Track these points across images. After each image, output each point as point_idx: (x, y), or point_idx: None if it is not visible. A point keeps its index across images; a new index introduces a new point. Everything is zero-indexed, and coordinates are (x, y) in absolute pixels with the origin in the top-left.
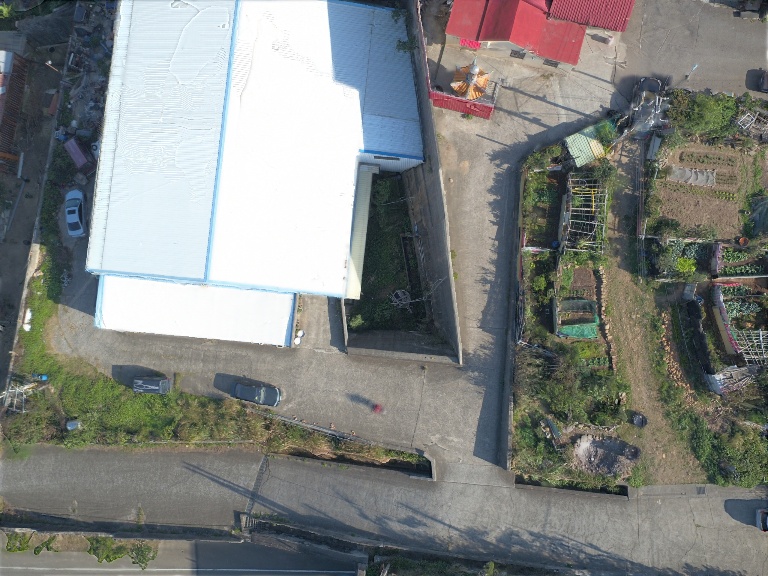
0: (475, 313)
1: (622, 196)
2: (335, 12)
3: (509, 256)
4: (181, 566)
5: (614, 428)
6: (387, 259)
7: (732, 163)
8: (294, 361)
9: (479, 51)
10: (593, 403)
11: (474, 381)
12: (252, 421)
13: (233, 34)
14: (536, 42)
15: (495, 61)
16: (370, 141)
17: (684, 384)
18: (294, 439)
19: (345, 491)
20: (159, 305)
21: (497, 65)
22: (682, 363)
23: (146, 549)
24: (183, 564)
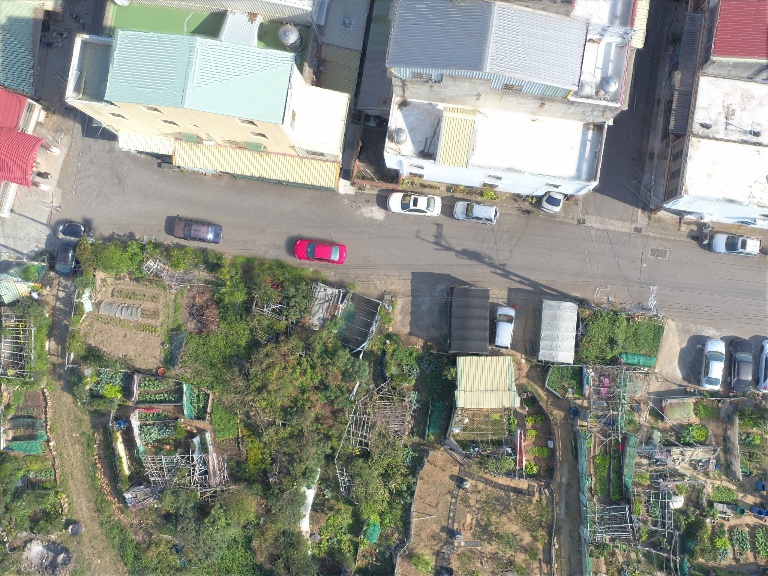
0: None
1: (62, 326)
2: None
3: None
4: None
5: (57, 535)
6: None
7: (155, 300)
8: None
9: None
10: (41, 511)
11: None
12: None
13: None
14: None
15: None
16: None
17: (113, 498)
18: None
19: None
20: None
21: None
22: (111, 479)
23: None
24: None
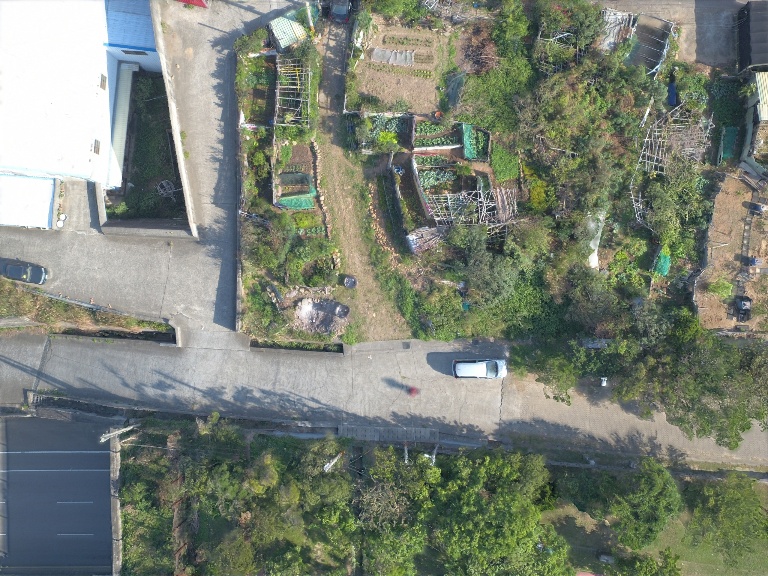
0: (208, 190)
1: (332, 77)
2: None
3: (234, 136)
4: None
5: (330, 291)
6: (154, 153)
7: (429, 44)
8: (59, 243)
9: None
10: (312, 269)
11: (212, 254)
12: (21, 298)
13: None
14: None
15: None
16: (115, 36)
17: (389, 248)
18: (57, 313)
19: (111, 363)
20: None
21: None
22: (387, 229)
23: None
24: None
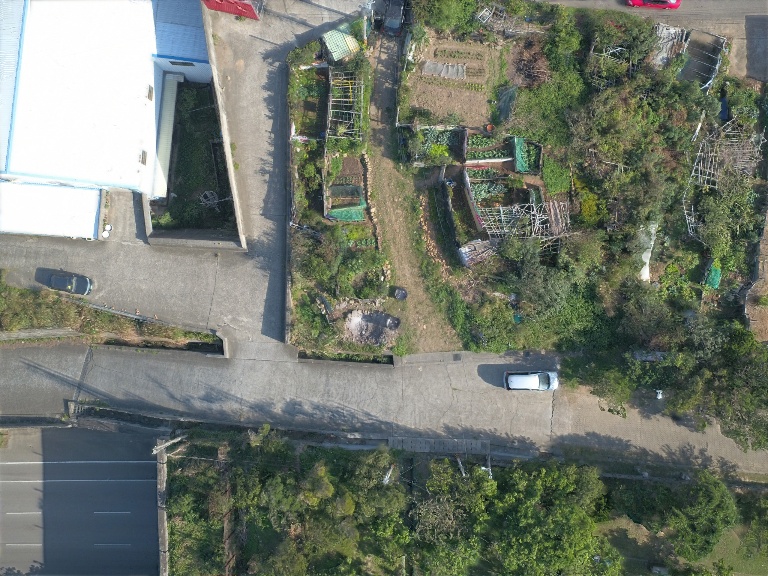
0: (257, 201)
1: (383, 90)
2: None
3: (284, 147)
4: (29, 459)
5: (380, 303)
6: (198, 163)
7: (481, 57)
8: (104, 253)
9: None
10: (362, 280)
11: (260, 265)
12: (66, 309)
13: None
14: None
15: None
16: (163, 47)
17: (440, 260)
18: (103, 324)
19: (155, 374)
20: None
21: None
22: (438, 241)
23: None
24: (31, 458)
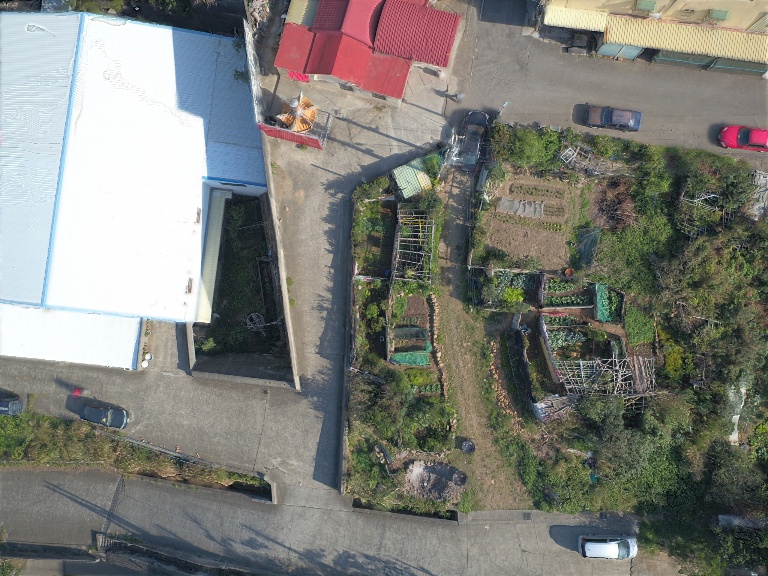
0: (313, 339)
1: (453, 226)
2: (182, 40)
3: (345, 284)
4: None
5: (445, 454)
6: (243, 282)
7: (560, 195)
8: (142, 384)
9: (312, 82)
10: (425, 429)
11: (313, 406)
12: (100, 443)
13: (75, 61)
14: (361, 75)
15: (329, 92)
16: (214, 168)
17: (511, 412)
18: (140, 461)
19: (194, 512)
20: (5, 327)
21: (331, 96)
22: (510, 391)
23: (7, 567)
24: None
